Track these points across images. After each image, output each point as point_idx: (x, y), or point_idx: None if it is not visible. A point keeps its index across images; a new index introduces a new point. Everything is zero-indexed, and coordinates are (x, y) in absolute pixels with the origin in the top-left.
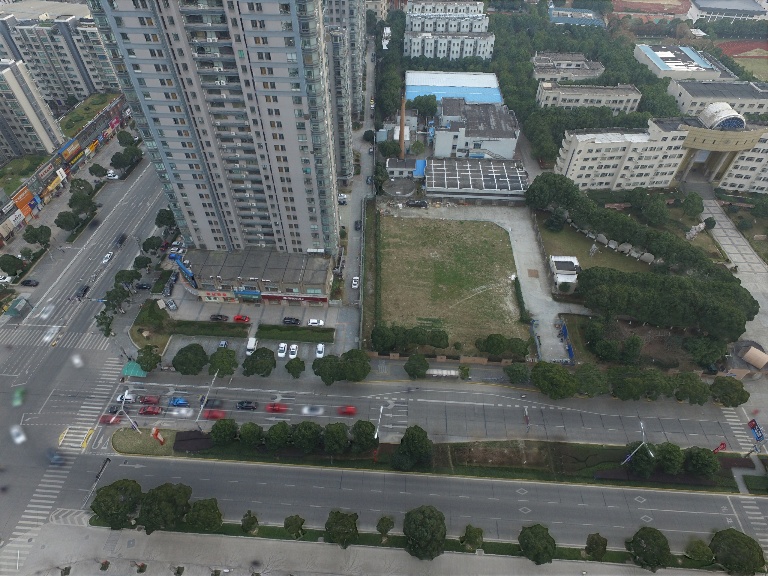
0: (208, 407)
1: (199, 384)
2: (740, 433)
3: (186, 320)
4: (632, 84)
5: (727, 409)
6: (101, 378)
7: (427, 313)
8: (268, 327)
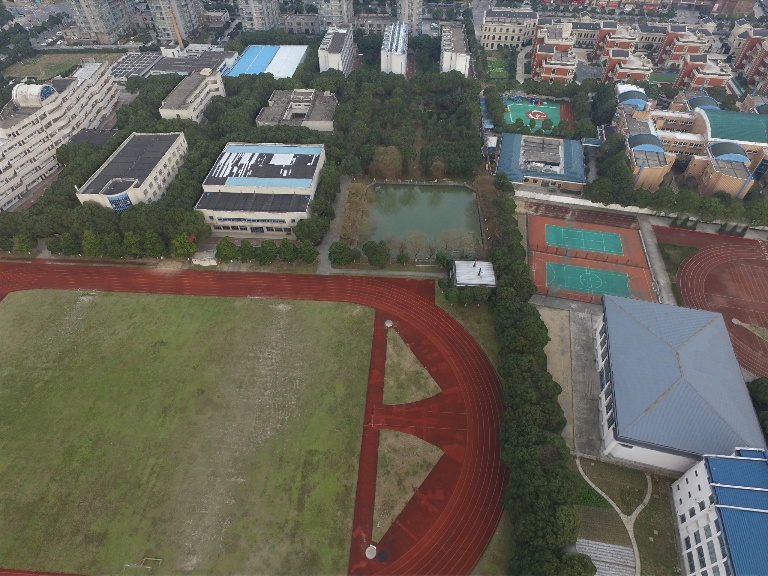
0: None
1: (53, 30)
2: None
3: None
4: (186, 109)
5: None
6: (73, 19)
7: None
8: None
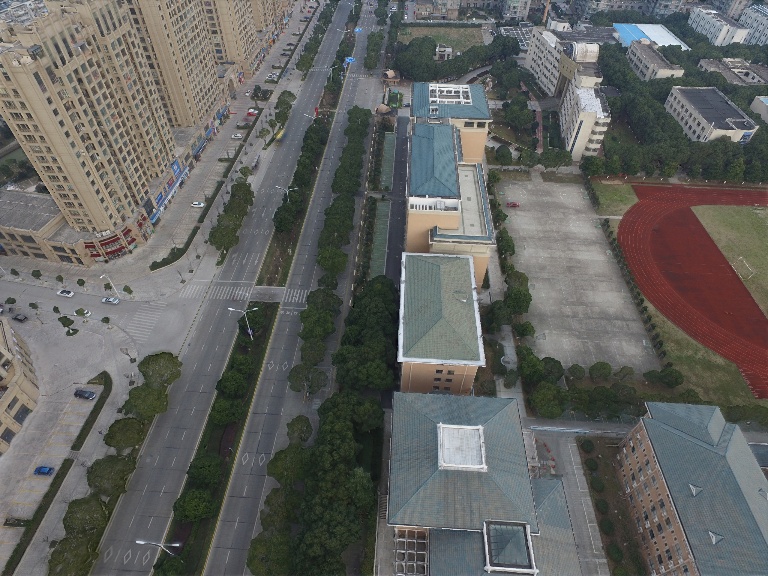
0: (370, 8)
1: None
2: (356, 75)
3: (405, 3)
4: (683, 70)
5: (367, 76)
6: None
7: (414, 33)
8: None
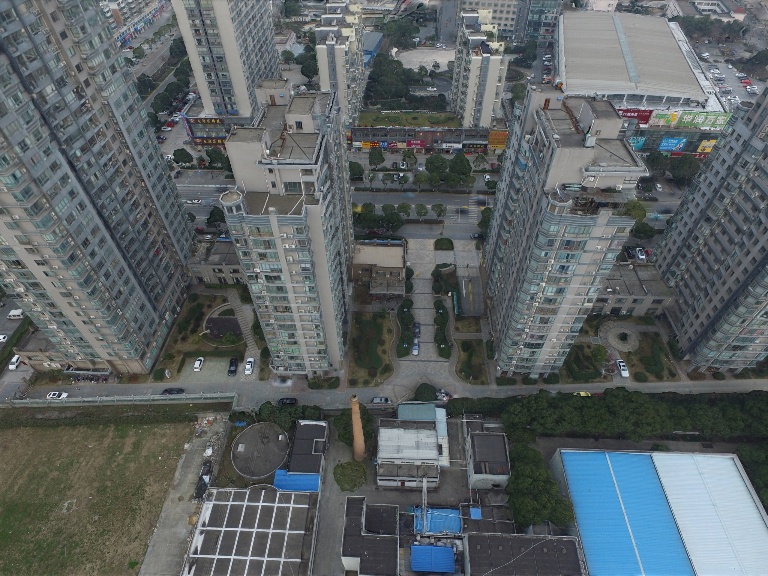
0: None
1: None
2: None
3: None
4: None
5: None
6: None
7: None
8: (32, 322)
